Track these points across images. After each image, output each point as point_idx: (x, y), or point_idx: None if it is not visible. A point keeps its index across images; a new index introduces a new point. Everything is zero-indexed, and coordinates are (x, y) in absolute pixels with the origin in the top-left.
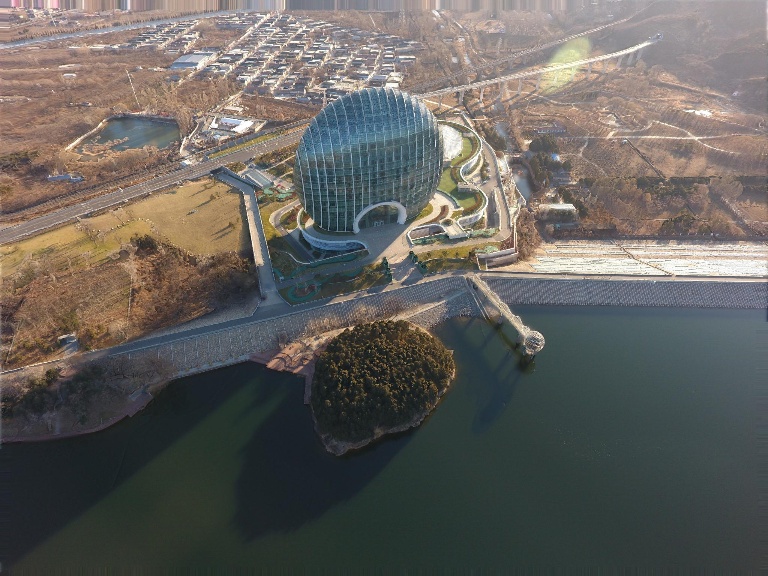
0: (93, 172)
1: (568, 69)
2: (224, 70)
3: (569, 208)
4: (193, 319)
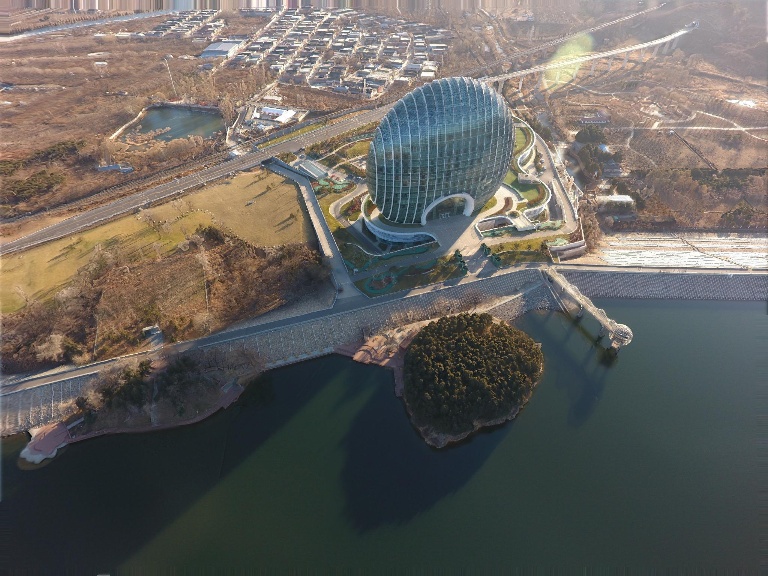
0: (140, 162)
1: (603, 58)
2: (256, 58)
3: (627, 200)
4: (270, 311)
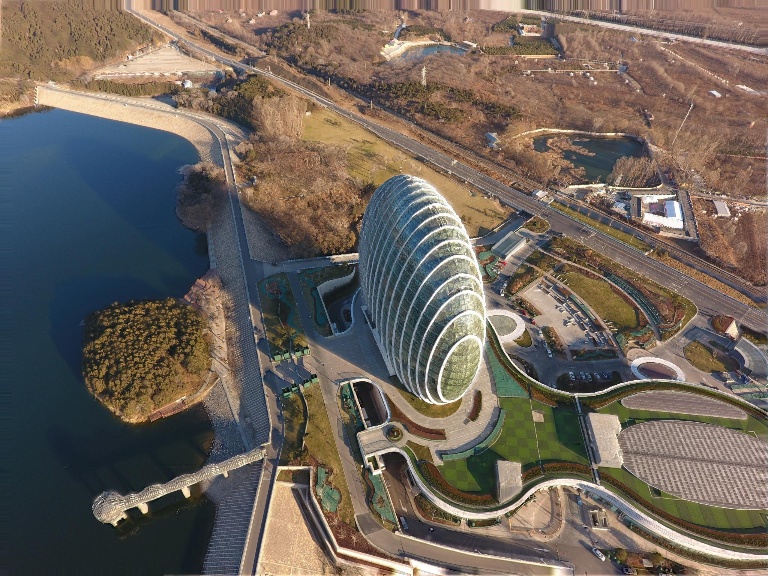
0: None
1: None
2: None
3: None
4: None
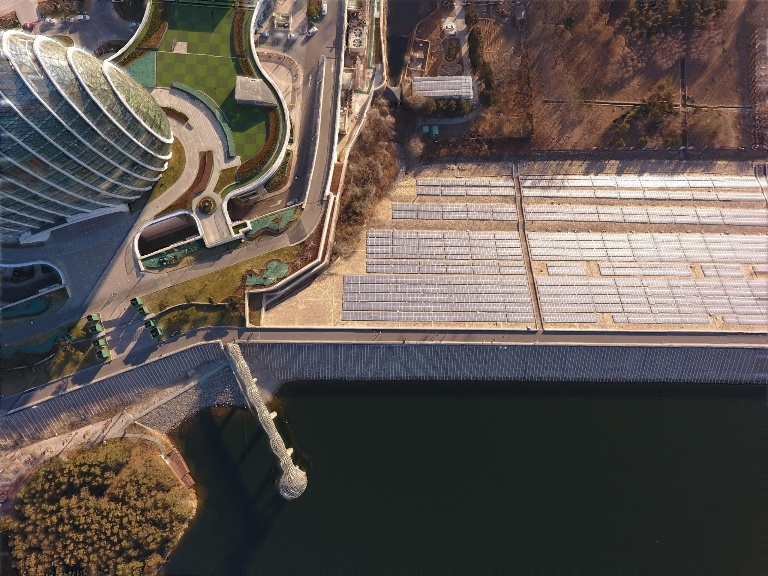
0: None
1: None
2: None
3: (461, 94)
4: None
